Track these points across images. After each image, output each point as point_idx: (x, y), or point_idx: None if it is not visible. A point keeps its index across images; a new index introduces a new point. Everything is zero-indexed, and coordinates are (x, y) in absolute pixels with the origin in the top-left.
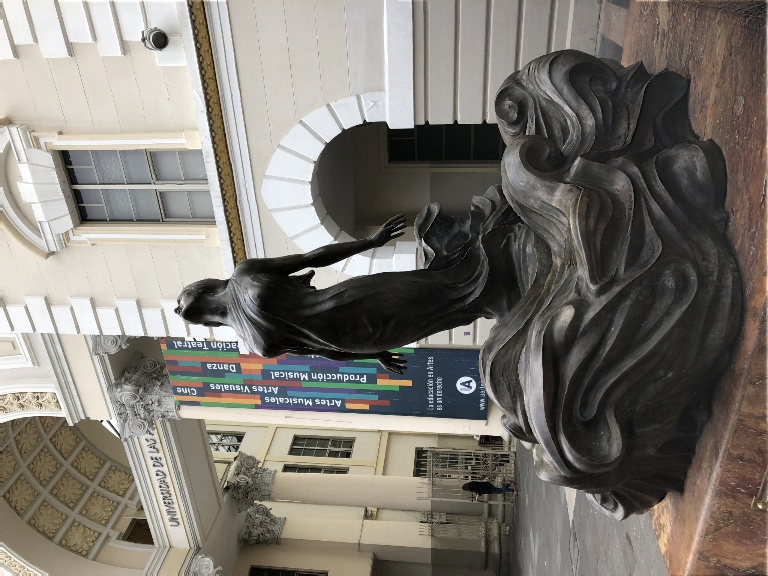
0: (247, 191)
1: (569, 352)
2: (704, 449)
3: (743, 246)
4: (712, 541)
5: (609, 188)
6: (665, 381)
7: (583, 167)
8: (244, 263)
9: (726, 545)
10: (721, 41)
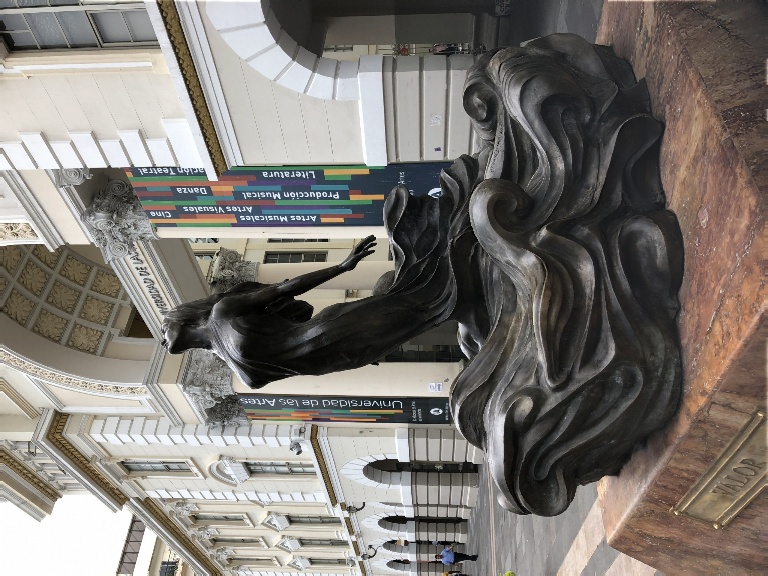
0: (190, 10)
1: (527, 431)
2: (637, 465)
3: (688, 349)
4: (637, 521)
5: (573, 263)
6: (608, 446)
7: (549, 239)
8: (221, 302)
9: (647, 525)
10: (697, 127)
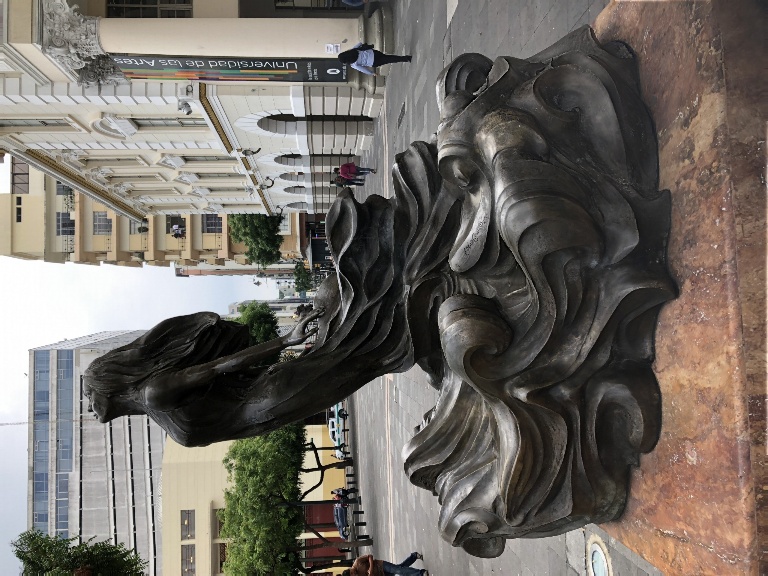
0: None
1: None
2: None
3: (636, 504)
4: None
5: (546, 420)
6: None
7: None
8: (153, 389)
9: None
10: (717, 375)
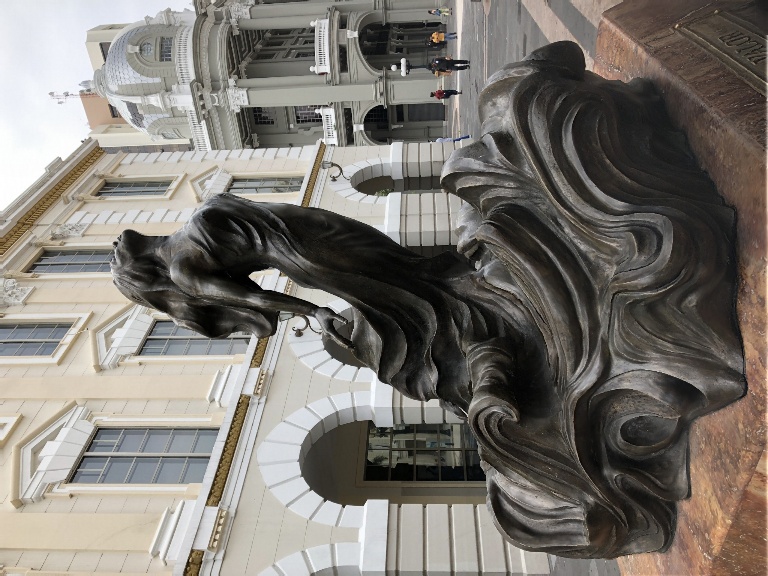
0: None
1: None
2: (701, 144)
3: None
4: None
5: None
6: None
7: None
8: None
9: None
10: None
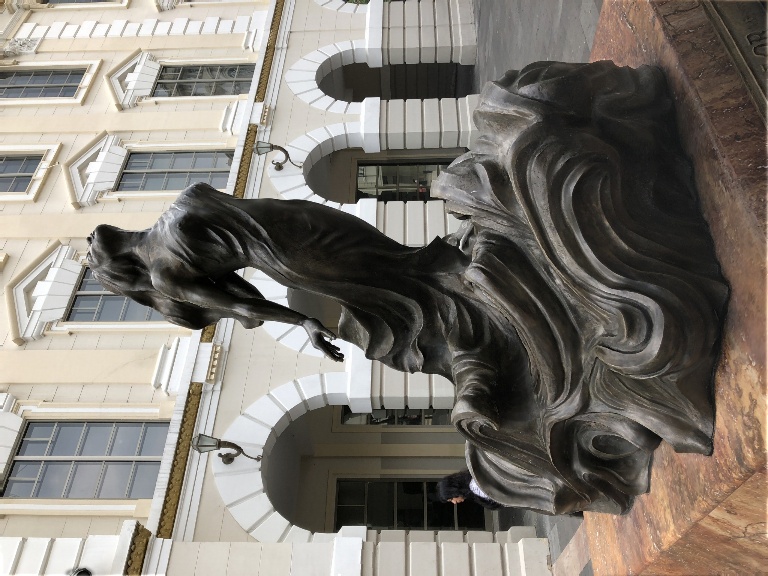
0: None
1: None
2: (707, 191)
3: (639, 65)
4: None
5: None
6: None
7: None
8: None
9: None
10: None
